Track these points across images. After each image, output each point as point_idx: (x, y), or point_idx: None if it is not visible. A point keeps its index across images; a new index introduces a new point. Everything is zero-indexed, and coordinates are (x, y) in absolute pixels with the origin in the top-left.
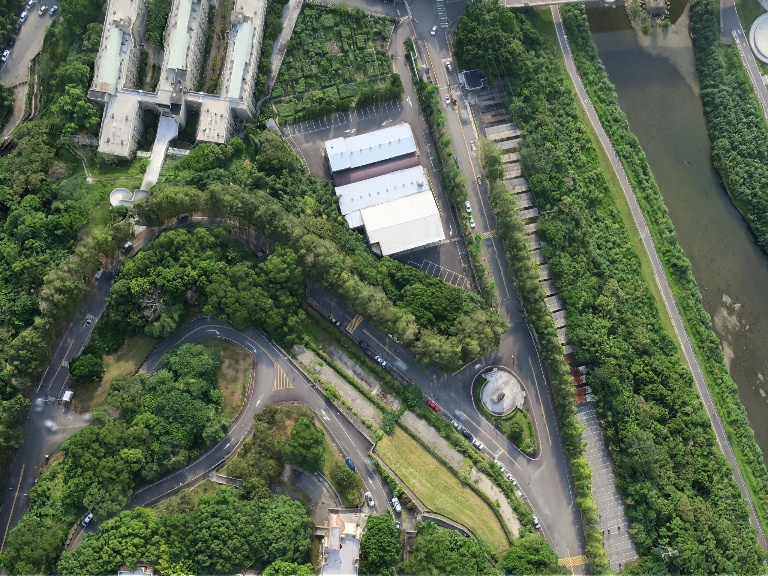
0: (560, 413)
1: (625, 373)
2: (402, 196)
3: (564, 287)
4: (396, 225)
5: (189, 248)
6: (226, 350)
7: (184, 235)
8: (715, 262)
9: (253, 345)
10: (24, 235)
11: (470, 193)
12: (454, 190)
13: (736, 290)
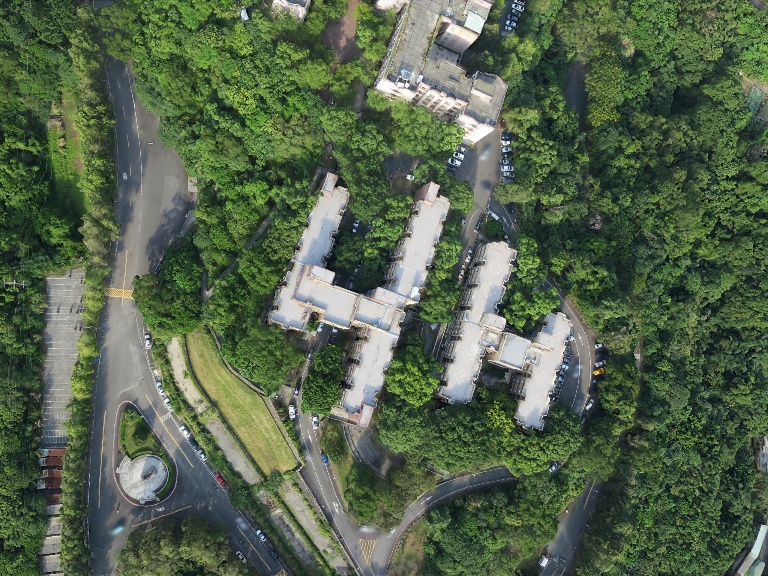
0: (87, 448)
1: None
2: None
3: None
4: None
5: None
6: None
7: None
8: None
9: None
10: None
11: None
12: None
13: None
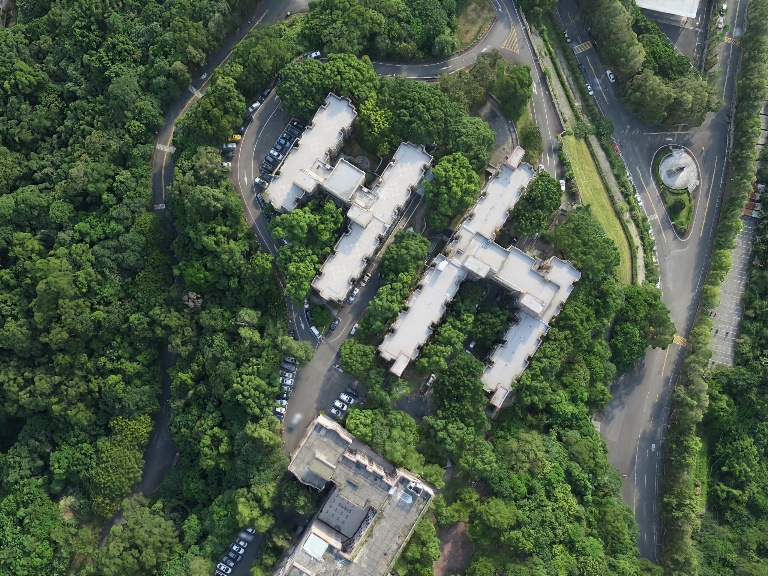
0: (727, 207)
1: None
2: None
3: None
4: None
5: None
6: None
7: None
8: None
9: (501, 4)
10: None
11: None
12: None
13: None
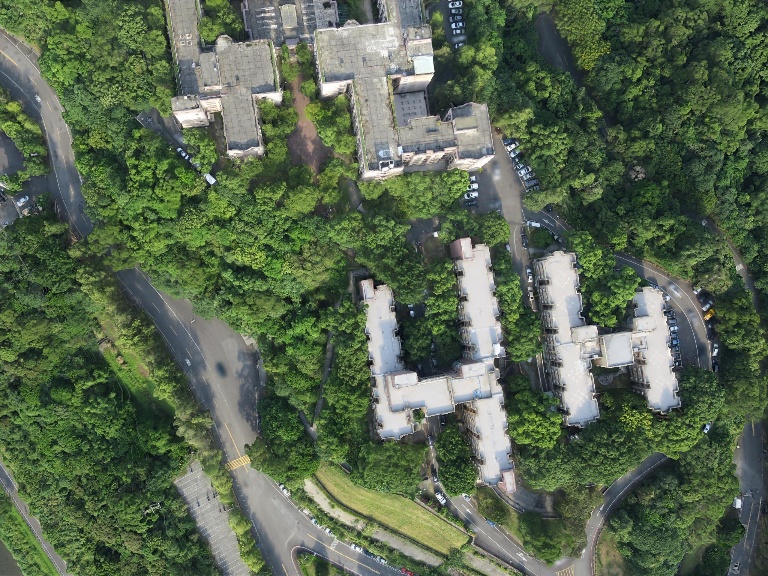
0: None
1: None
2: None
3: None
4: None
5: None
6: None
7: None
8: None
9: None
10: None
11: None
12: None
13: None
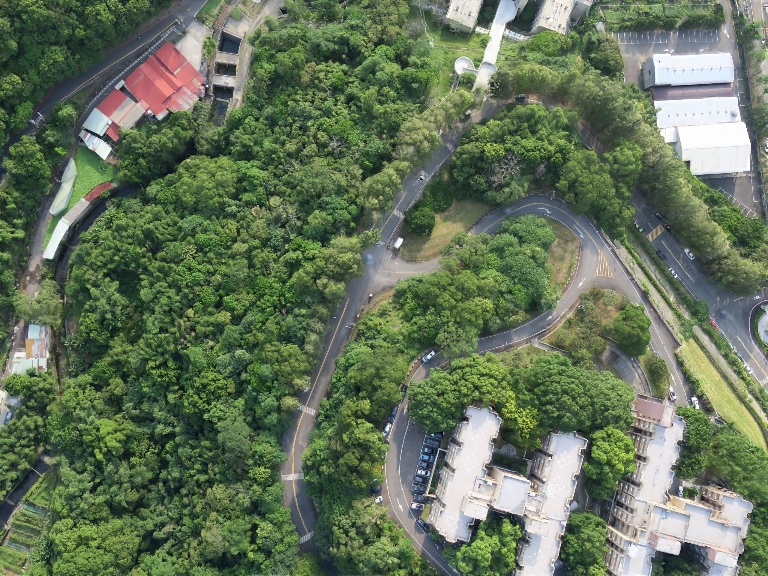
0: None
1: None
2: (717, 122)
3: None
4: (710, 148)
5: (547, 124)
6: (556, 229)
7: (543, 111)
8: None
9: (581, 230)
10: (383, 81)
11: None
12: (766, 127)
13: None
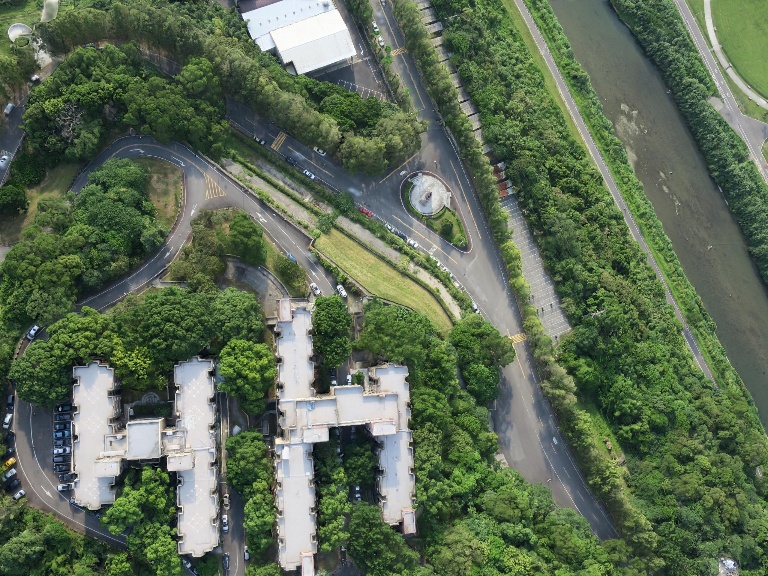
0: (485, 204)
1: (540, 166)
2: (309, 17)
3: (475, 91)
4: (307, 43)
5: (100, 64)
6: (153, 166)
7: (93, 52)
8: (611, 74)
9: (180, 159)
10: None
11: (375, 14)
12: (359, 7)
13: (632, 98)
